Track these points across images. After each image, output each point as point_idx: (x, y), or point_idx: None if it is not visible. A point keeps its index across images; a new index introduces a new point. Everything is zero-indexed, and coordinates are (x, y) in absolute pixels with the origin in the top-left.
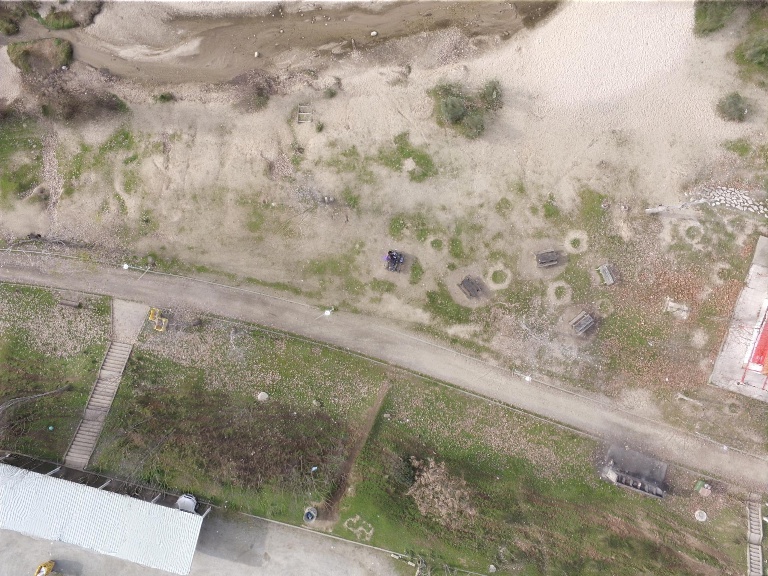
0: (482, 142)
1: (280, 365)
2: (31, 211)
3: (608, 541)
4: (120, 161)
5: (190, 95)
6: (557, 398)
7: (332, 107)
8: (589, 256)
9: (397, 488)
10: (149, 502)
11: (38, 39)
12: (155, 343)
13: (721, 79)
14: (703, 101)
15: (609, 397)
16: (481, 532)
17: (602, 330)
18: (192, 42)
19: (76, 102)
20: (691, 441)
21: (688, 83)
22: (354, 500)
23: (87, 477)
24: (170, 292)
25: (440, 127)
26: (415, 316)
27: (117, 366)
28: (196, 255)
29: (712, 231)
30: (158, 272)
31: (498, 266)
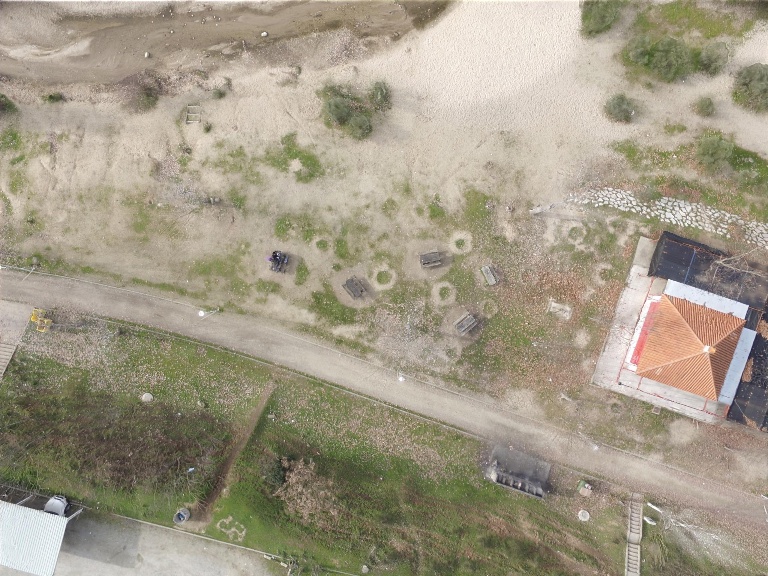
0: (370, 143)
1: (165, 366)
2: None
3: (484, 541)
4: (7, 161)
5: (80, 95)
6: (442, 398)
7: (221, 108)
8: (473, 257)
9: (274, 489)
10: (14, 504)
11: None
12: (39, 344)
13: (608, 80)
14: (591, 102)
15: (493, 397)
16: (357, 533)
17: (486, 330)
18: (82, 42)
19: None
20: (575, 441)
21: (576, 84)
22: (227, 501)
23: None
24: (55, 293)
25: (328, 128)
26: (300, 317)
27: None
28: (81, 256)
29: (594, 232)
30: (43, 273)
31: (383, 267)
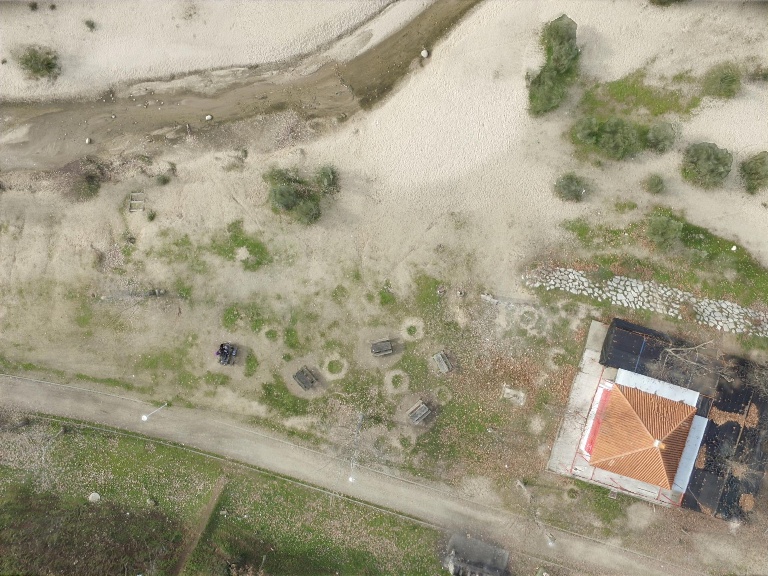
0: (318, 228)
1: (112, 464)
2: None
3: None
4: None
5: (19, 184)
6: (397, 488)
7: (165, 194)
8: (426, 343)
9: None
10: None
11: None
12: None
13: (558, 159)
14: (541, 181)
15: (449, 485)
16: None
17: (441, 418)
18: (20, 129)
19: None
20: (532, 527)
21: (525, 164)
22: None
23: None
24: None
25: (275, 214)
26: (251, 409)
27: None
28: (23, 352)
29: (546, 316)
30: None
31: (334, 356)
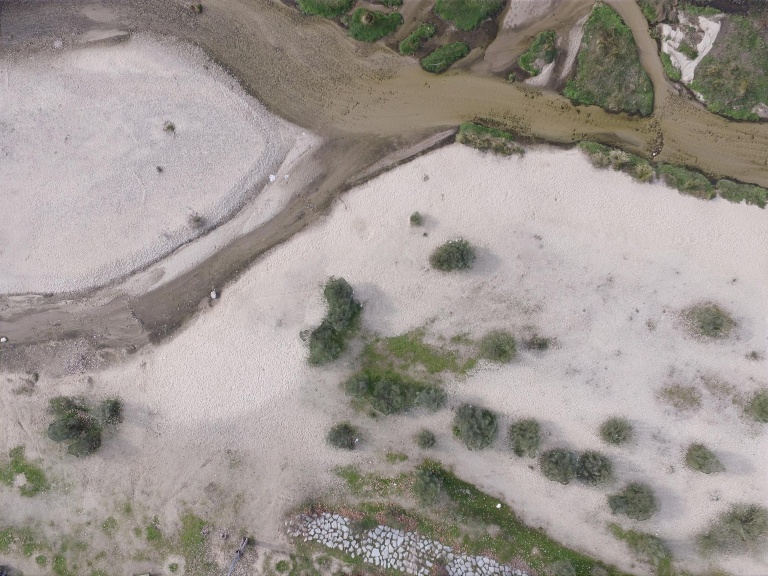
0: (97, 458)
1: None
2: None
3: None
4: None
5: None
6: None
7: None
8: None
9: None
10: None
11: None
12: None
13: (334, 407)
14: (316, 427)
15: None
16: None
17: None
18: None
19: None
20: None
21: (302, 409)
22: None
23: None
24: None
25: (56, 442)
26: None
27: None
28: None
29: (300, 567)
30: None
31: None
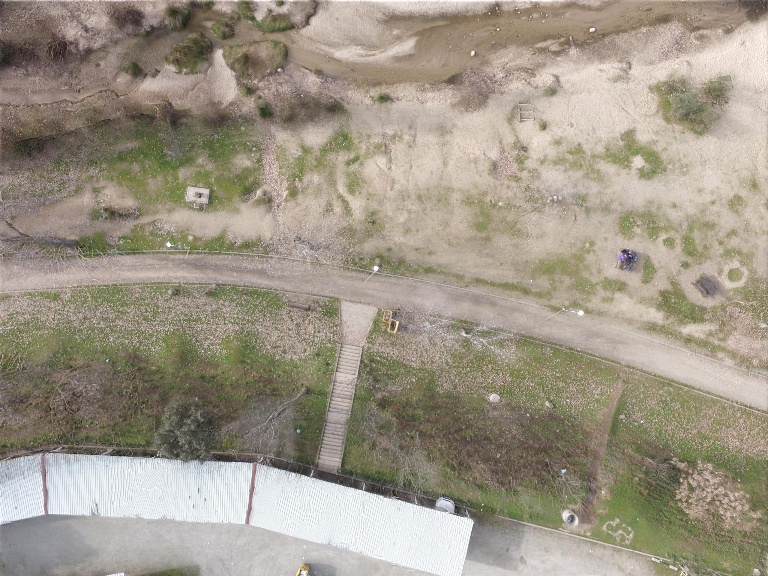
0: (710, 138)
1: (510, 366)
2: (256, 214)
3: None
4: (342, 163)
5: (406, 95)
6: None
7: (553, 105)
8: None
9: (649, 491)
10: (418, 505)
11: (253, 42)
12: (384, 345)
13: None
14: None
15: None
16: (738, 535)
17: None
18: (407, 42)
19: (295, 104)
20: None
21: None
22: (611, 503)
23: (342, 480)
24: (398, 294)
25: (667, 123)
26: (648, 316)
27: (351, 368)
28: (423, 256)
29: None
30: (385, 274)
31: (734, 264)
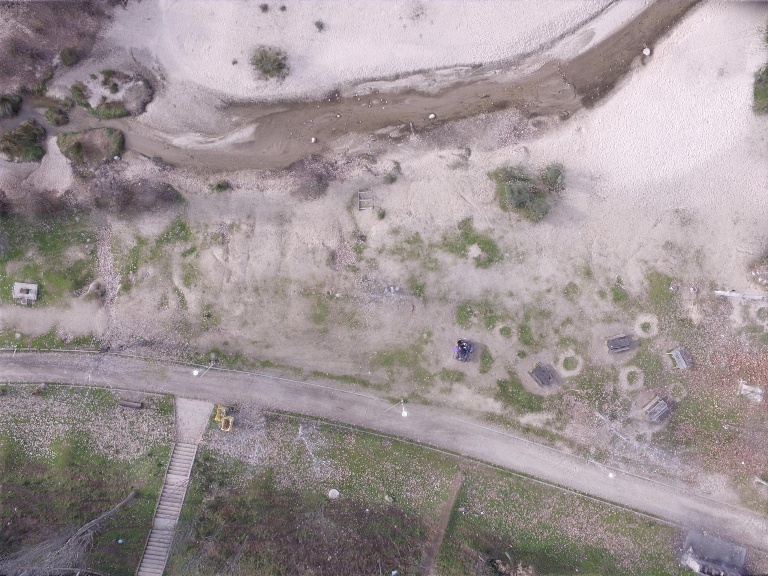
0: (546, 225)
1: (350, 460)
2: (88, 309)
3: None
4: (178, 254)
5: (247, 183)
6: (633, 485)
7: (393, 193)
8: (660, 340)
9: None
10: None
11: (88, 129)
12: (220, 442)
13: None
14: (765, 178)
15: (685, 482)
16: None
17: (676, 414)
18: (247, 129)
19: (130, 194)
20: None
21: (749, 160)
22: None
23: None
24: (234, 389)
25: (504, 211)
26: (486, 406)
27: (183, 469)
28: (260, 350)
29: None
30: (221, 368)
31: (569, 352)
